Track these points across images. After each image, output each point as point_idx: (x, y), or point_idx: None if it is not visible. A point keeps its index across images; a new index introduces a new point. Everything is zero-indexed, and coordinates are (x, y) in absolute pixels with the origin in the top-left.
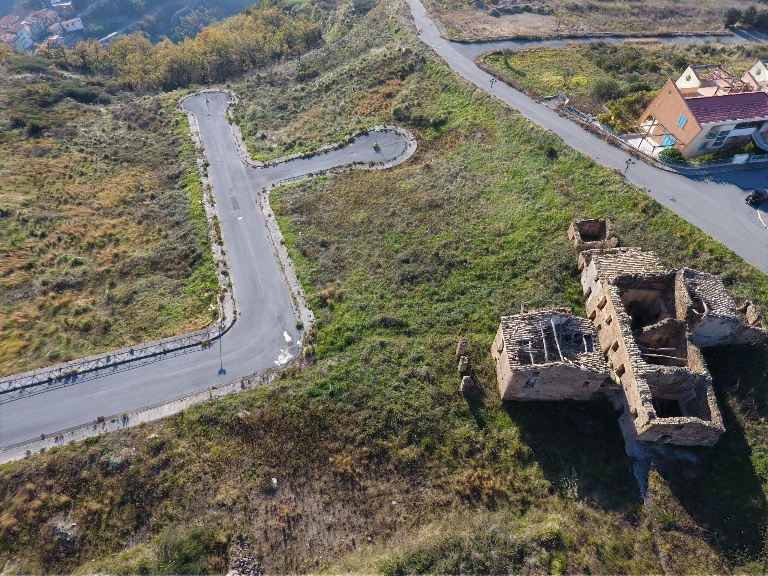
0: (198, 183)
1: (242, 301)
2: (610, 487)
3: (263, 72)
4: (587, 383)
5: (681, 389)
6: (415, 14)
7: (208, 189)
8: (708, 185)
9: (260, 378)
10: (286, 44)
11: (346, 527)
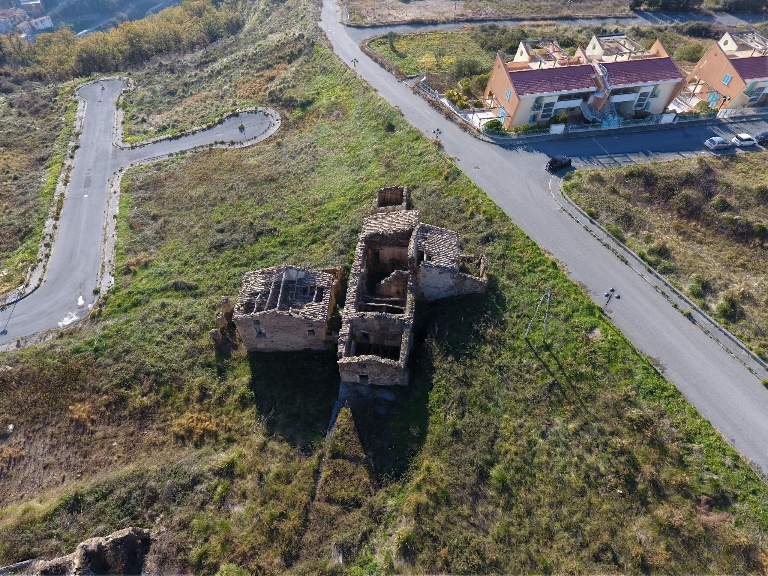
0: (60, 164)
1: (52, 270)
2: (308, 424)
3: (167, 60)
4: (313, 332)
5: (393, 334)
6: (326, 1)
7: (67, 169)
8: (518, 154)
9: (38, 338)
10: (207, 34)
11: (62, 466)
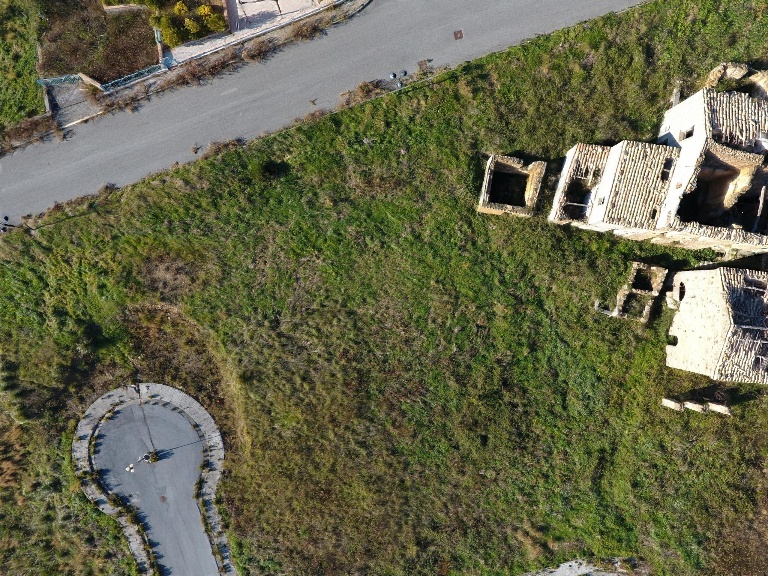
0: None
1: None
2: None
3: None
4: None
5: None
6: None
7: None
8: None
9: None
10: None
11: None
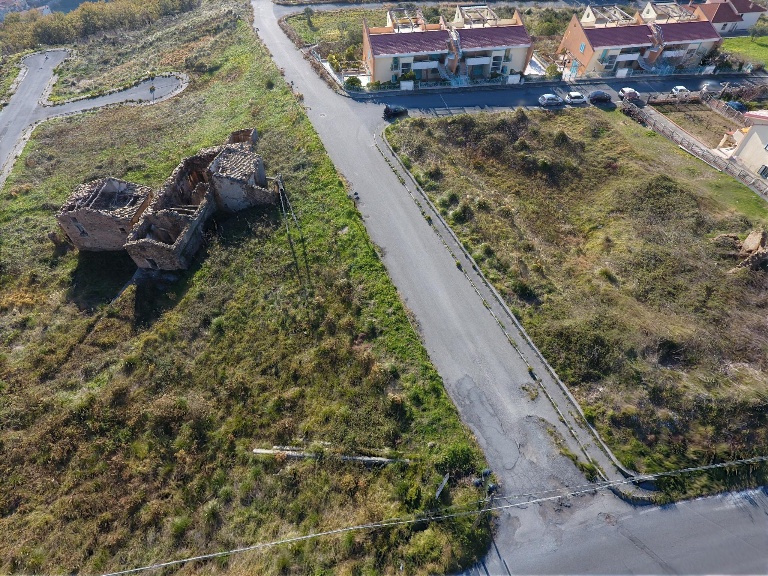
0: None
1: None
2: None
3: (113, 35)
4: None
5: None
6: None
7: None
8: (365, 105)
9: None
10: None
11: None
